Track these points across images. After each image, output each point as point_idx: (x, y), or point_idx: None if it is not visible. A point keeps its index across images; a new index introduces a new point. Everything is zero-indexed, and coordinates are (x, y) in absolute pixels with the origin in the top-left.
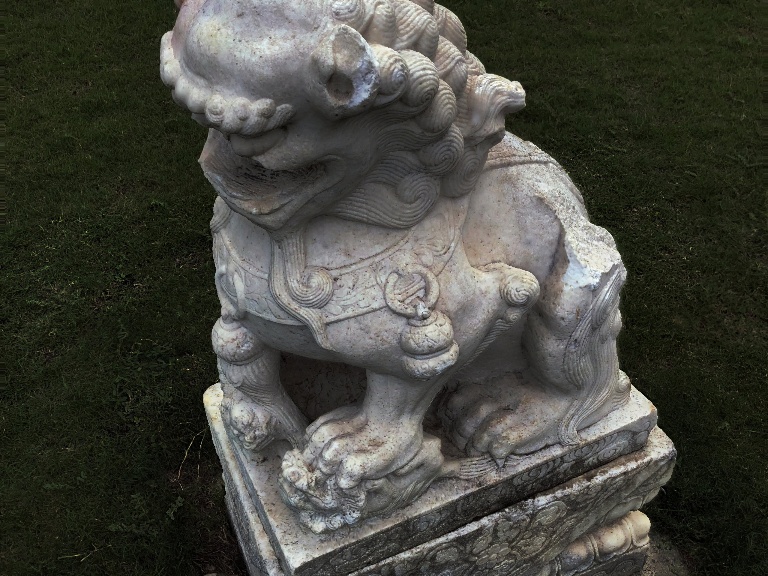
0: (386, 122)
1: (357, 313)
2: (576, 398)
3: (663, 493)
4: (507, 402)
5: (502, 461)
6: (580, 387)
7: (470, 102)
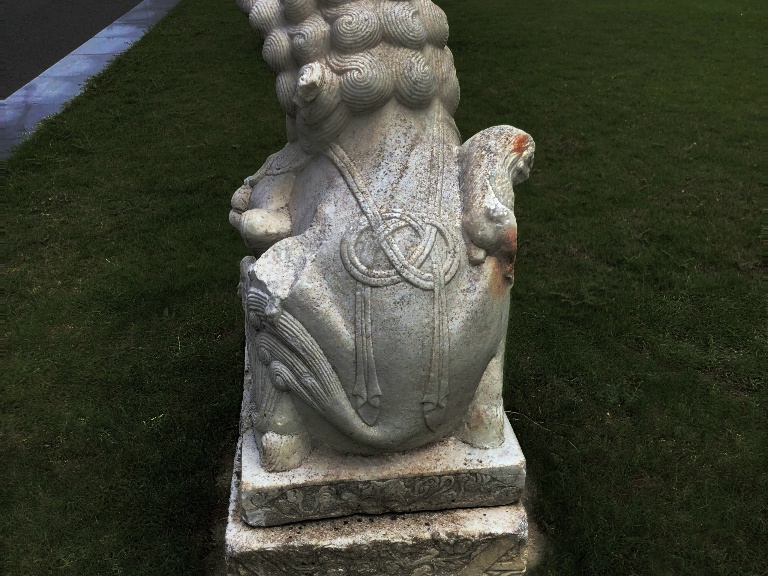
0: None
1: None
2: None
3: None
4: None
5: None
6: None
7: None
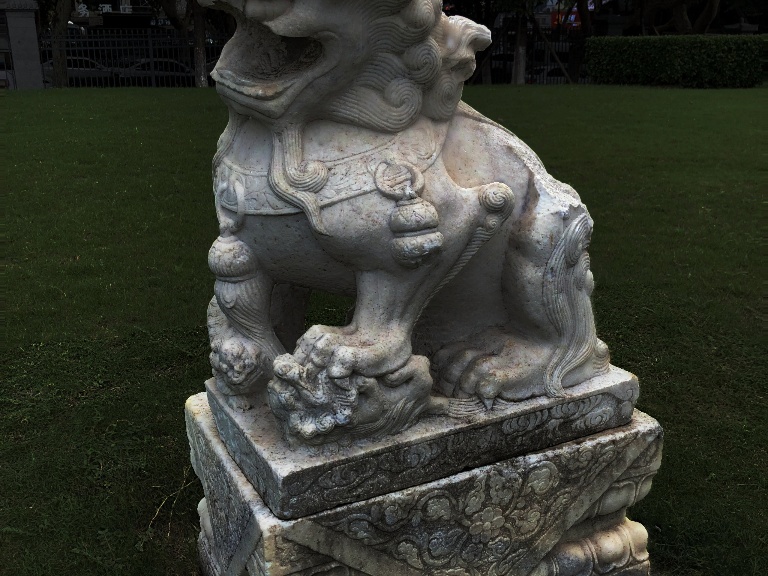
0: (376, 12)
1: (350, 195)
2: (558, 346)
3: (658, 531)
4: (491, 349)
5: (490, 403)
6: (560, 332)
7: (445, 29)
